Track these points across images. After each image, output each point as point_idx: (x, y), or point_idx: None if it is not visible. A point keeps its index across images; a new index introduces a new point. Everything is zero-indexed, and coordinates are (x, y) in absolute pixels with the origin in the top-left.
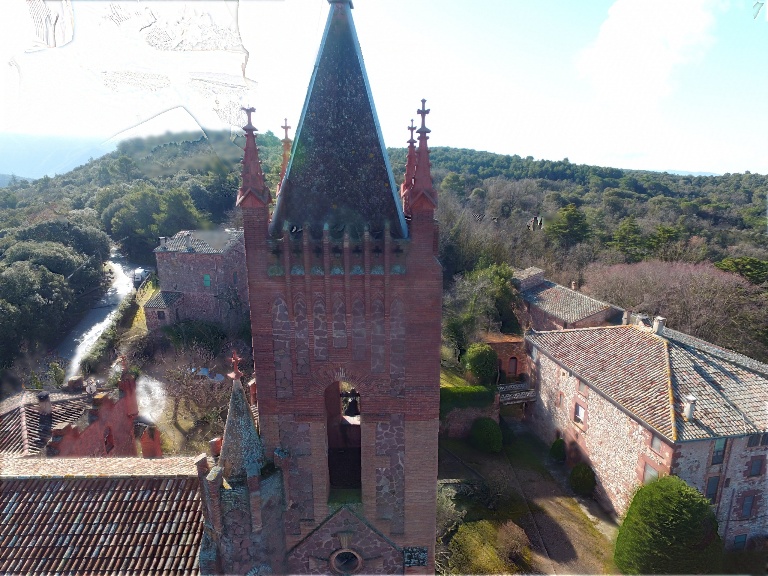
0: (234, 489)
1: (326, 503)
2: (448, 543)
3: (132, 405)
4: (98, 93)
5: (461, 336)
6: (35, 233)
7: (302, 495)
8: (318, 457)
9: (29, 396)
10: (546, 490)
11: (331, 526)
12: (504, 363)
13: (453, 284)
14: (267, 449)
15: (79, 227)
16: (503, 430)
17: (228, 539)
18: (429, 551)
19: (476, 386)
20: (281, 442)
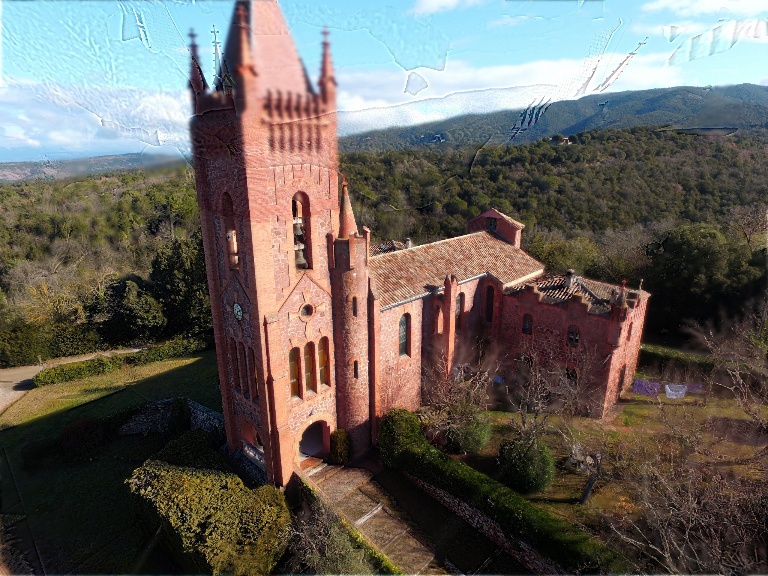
0: None
1: None
2: None
3: (611, 333)
4: (513, 8)
5: None
6: None
7: None
8: None
9: None
10: None
11: None
12: None
13: None
14: None
15: None
16: None
17: None
18: None
19: None
20: None
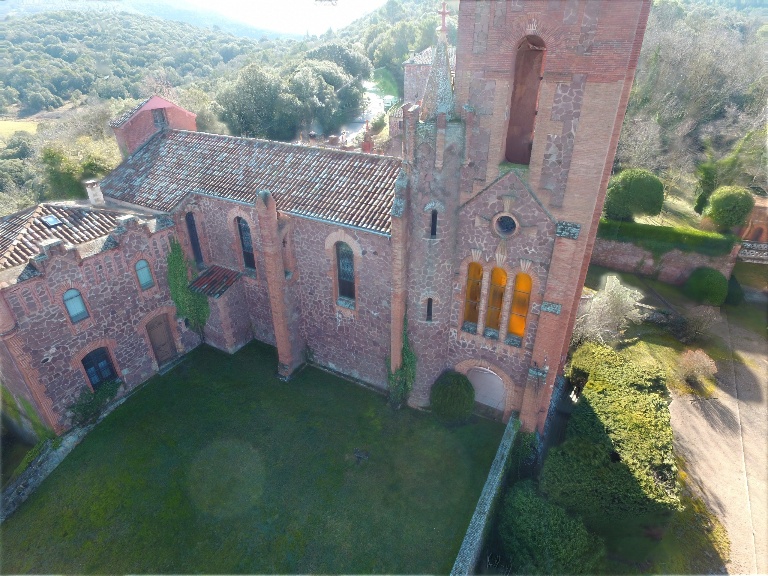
0: (426, 124)
1: (498, 165)
2: (621, 349)
3: None
4: None
5: (711, 179)
6: (318, 55)
7: (479, 155)
8: (498, 117)
9: None
10: (764, 351)
11: (498, 189)
12: (766, 234)
13: (721, 115)
14: (457, 106)
15: (349, 51)
16: (731, 288)
17: (417, 171)
18: (582, 229)
19: (711, 232)
20: (469, 100)
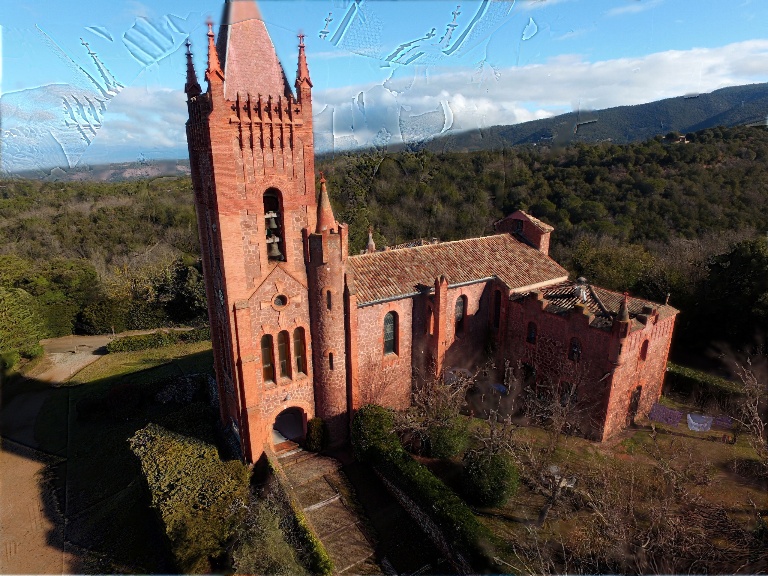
0: None
1: None
2: None
3: None
4: None
5: None
6: None
7: None
8: None
9: (641, 302)
10: None
11: None
12: None
13: None
14: None
15: None
16: None
17: None
18: None
19: None
20: None
